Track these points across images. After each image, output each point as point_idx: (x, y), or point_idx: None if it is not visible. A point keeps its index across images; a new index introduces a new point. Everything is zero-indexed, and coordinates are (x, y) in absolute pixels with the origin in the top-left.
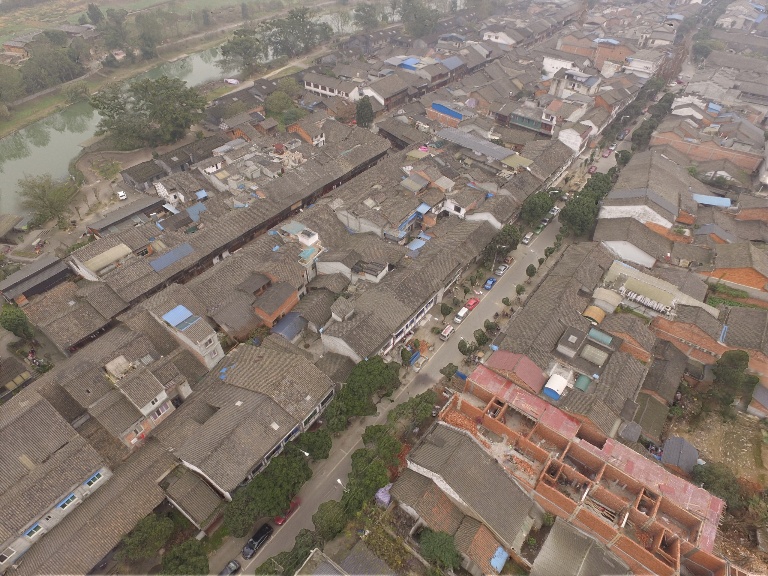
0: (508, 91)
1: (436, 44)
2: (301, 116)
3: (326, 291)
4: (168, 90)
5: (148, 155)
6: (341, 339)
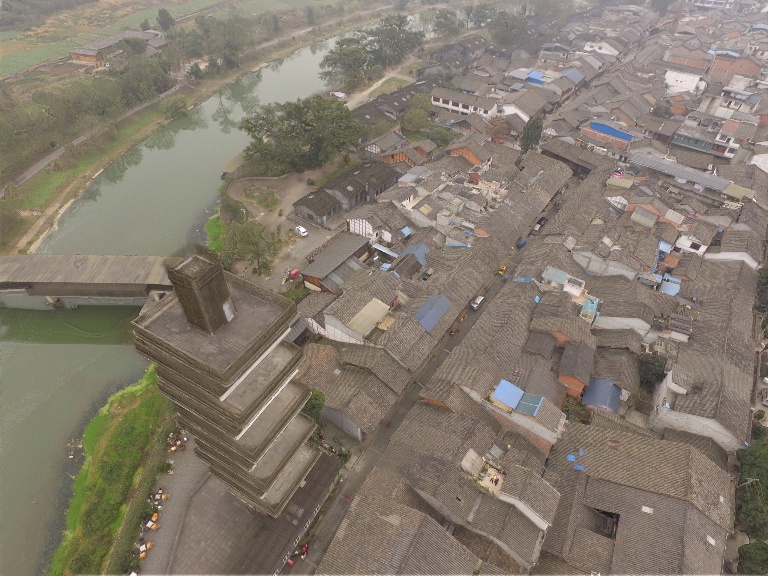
0: (644, 107)
1: (536, 54)
2: (447, 136)
3: (625, 351)
4: (331, 111)
5: (300, 182)
6: (713, 420)
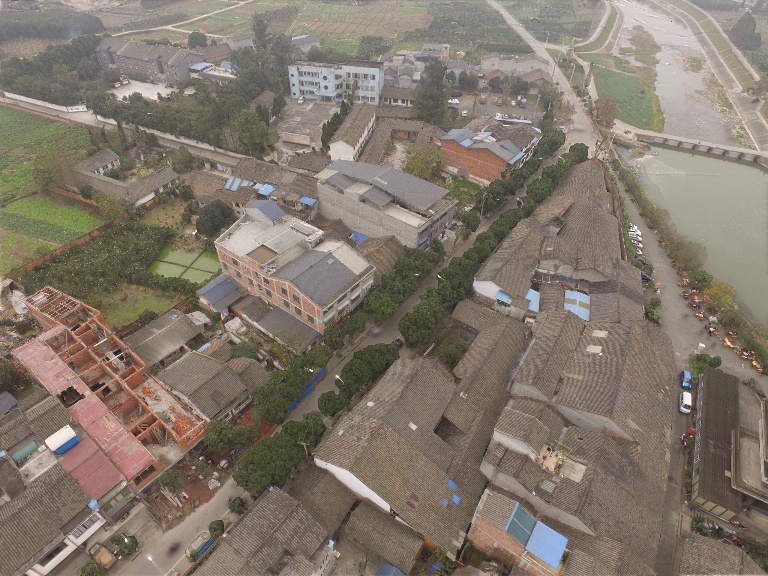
0: None
1: None
2: None
3: None
4: None
5: None
6: (300, 505)
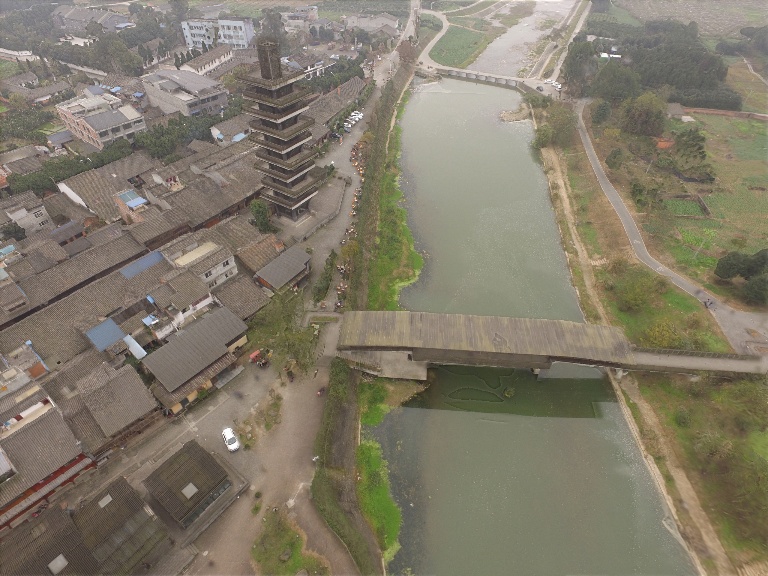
0: None
1: None
2: None
3: None
4: None
5: None
6: None
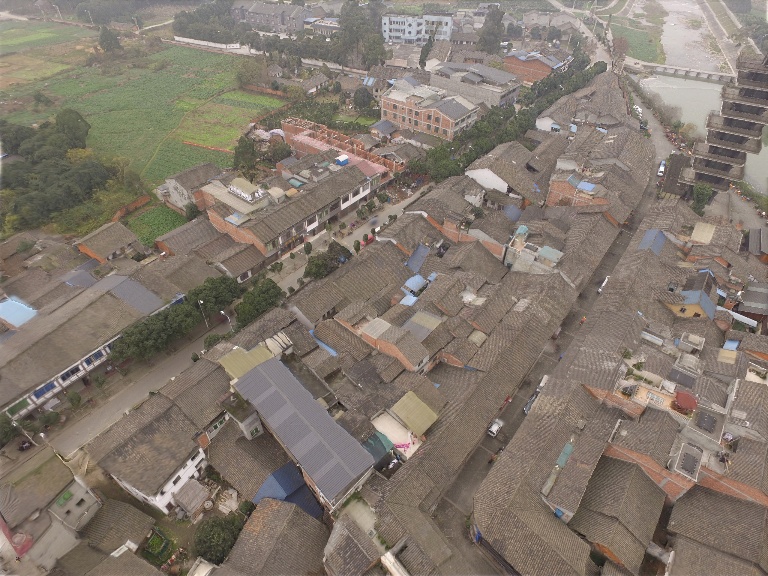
0: None
1: None
2: None
3: None
4: None
5: None
6: None
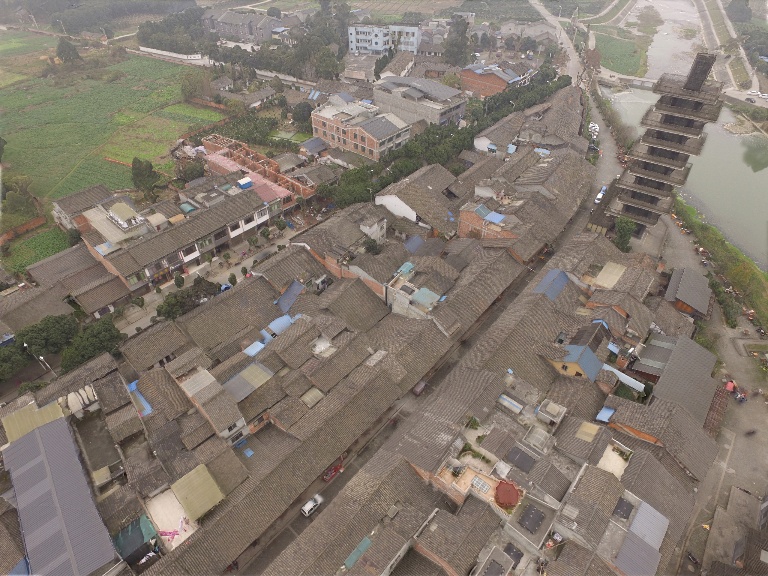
0: None
1: None
2: None
3: None
4: None
5: None
6: None
